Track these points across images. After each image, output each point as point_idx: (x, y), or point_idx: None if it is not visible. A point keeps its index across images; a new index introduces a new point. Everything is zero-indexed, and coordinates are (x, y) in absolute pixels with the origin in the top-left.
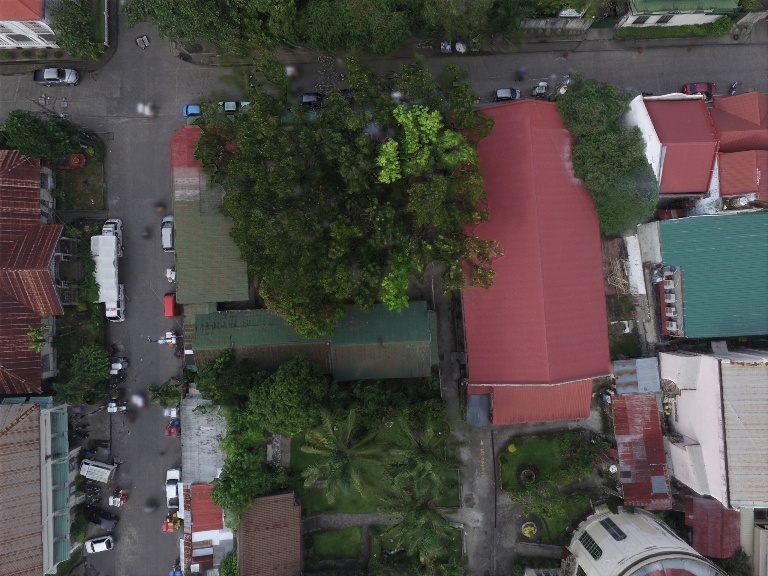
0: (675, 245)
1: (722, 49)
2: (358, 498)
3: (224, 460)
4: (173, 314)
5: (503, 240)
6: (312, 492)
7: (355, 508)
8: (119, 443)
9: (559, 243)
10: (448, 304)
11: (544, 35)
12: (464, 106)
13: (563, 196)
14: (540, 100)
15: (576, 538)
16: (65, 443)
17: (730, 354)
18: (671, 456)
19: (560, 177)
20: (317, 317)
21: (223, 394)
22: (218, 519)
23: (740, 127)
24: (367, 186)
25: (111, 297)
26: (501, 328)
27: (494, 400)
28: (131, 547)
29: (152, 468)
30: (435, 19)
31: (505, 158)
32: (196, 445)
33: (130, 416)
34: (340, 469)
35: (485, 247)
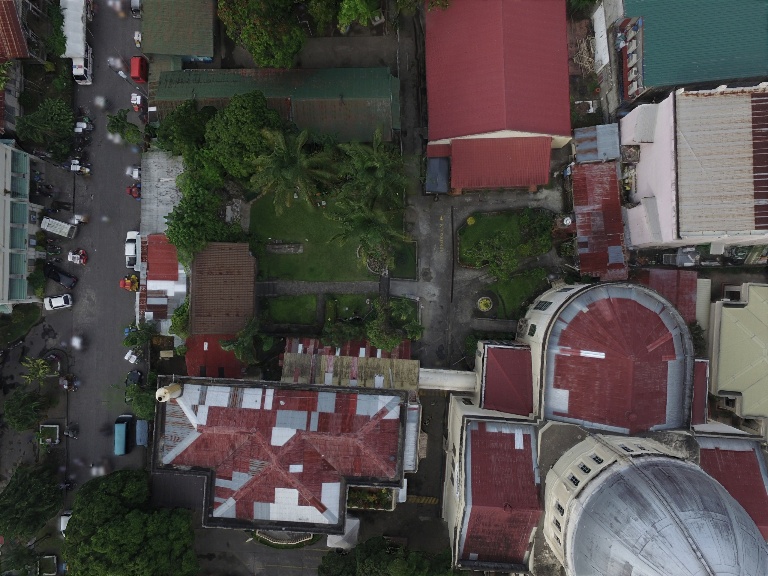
0: None
1: None
2: (315, 266)
3: (180, 200)
4: (139, 74)
5: None
6: (270, 257)
7: (312, 276)
8: (82, 206)
9: None
10: (413, 81)
11: None
12: None
13: None
14: None
15: (531, 308)
16: (25, 185)
17: None
18: (628, 224)
19: None
20: (272, 31)
21: (180, 125)
22: (174, 270)
23: None
24: None
25: (78, 51)
26: (461, 83)
27: (452, 158)
28: (89, 308)
29: (113, 232)
30: None
31: None
32: (155, 197)
33: (94, 180)
34: (285, 157)
35: None
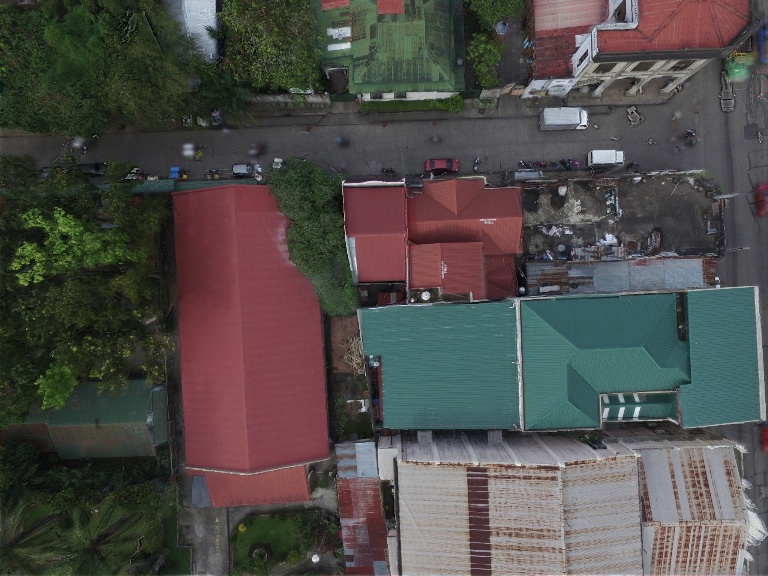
0: (375, 334)
1: (468, 123)
2: None
3: None
4: None
5: (212, 324)
6: (43, 568)
7: None
8: None
9: (267, 328)
10: None
11: (287, 108)
12: (113, 206)
13: (275, 280)
14: (247, 184)
15: None
16: None
17: (429, 446)
18: None
19: (272, 261)
20: None
21: None
22: None
23: (436, 216)
24: (9, 288)
25: None
26: (211, 412)
27: (208, 484)
28: None
29: None
30: (121, 107)
31: (215, 241)
32: None
33: None
34: None
35: (150, 343)
